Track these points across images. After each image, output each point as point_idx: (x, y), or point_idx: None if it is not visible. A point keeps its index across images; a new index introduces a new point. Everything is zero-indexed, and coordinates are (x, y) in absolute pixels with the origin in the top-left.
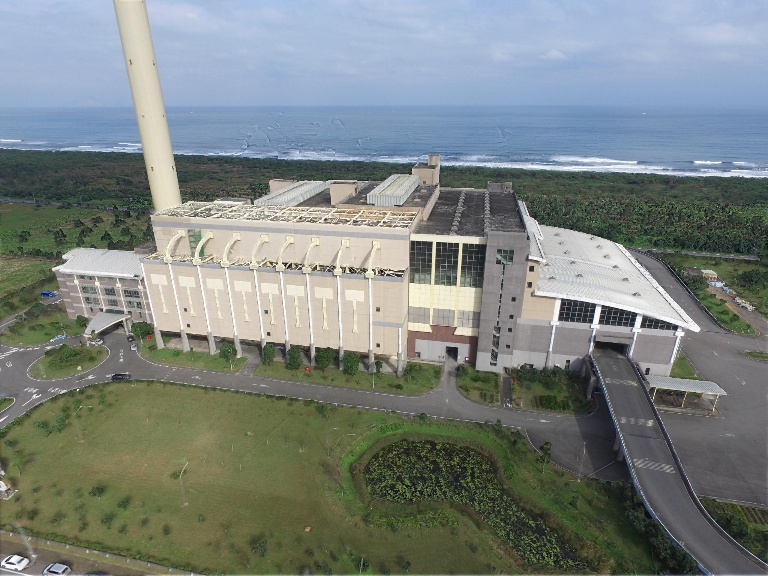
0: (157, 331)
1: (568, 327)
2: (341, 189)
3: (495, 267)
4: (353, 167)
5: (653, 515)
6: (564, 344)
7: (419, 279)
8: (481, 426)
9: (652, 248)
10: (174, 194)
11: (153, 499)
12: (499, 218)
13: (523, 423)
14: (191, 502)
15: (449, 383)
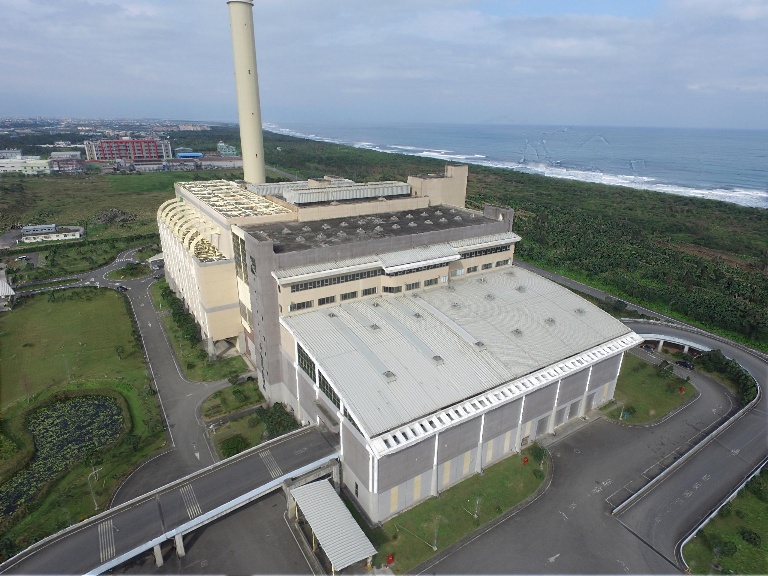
0: (165, 269)
1: (304, 377)
2: (313, 185)
3: (251, 275)
4: (608, 192)
5: (8, 560)
6: (305, 398)
7: (239, 273)
8: (157, 423)
9: None
10: (255, 176)
11: (2, 350)
12: (367, 236)
13: (183, 444)
14: (2, 360)
15: (221, 385)
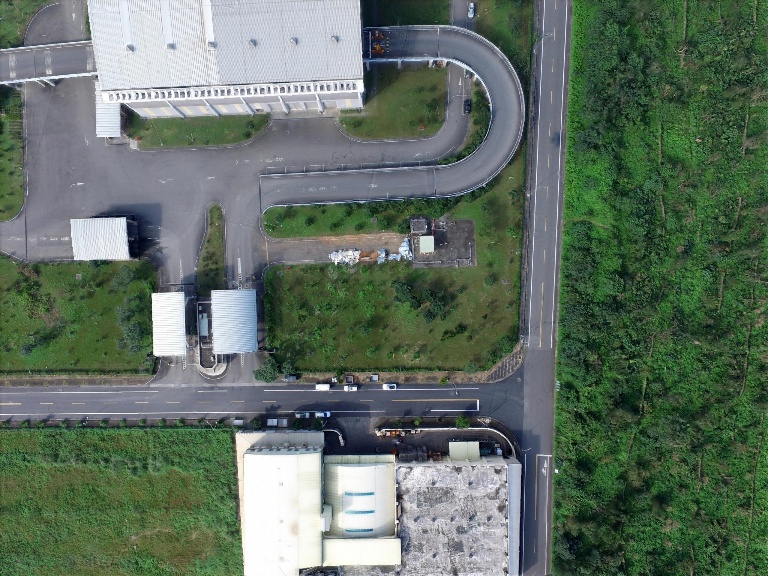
0: None
1: None
2: None
3: None
4: None
5: None
6: None
7: None
8: None
9: (563, 214)
10: None
11: None
12: None
13: (67, 1)
14: None
15: None
